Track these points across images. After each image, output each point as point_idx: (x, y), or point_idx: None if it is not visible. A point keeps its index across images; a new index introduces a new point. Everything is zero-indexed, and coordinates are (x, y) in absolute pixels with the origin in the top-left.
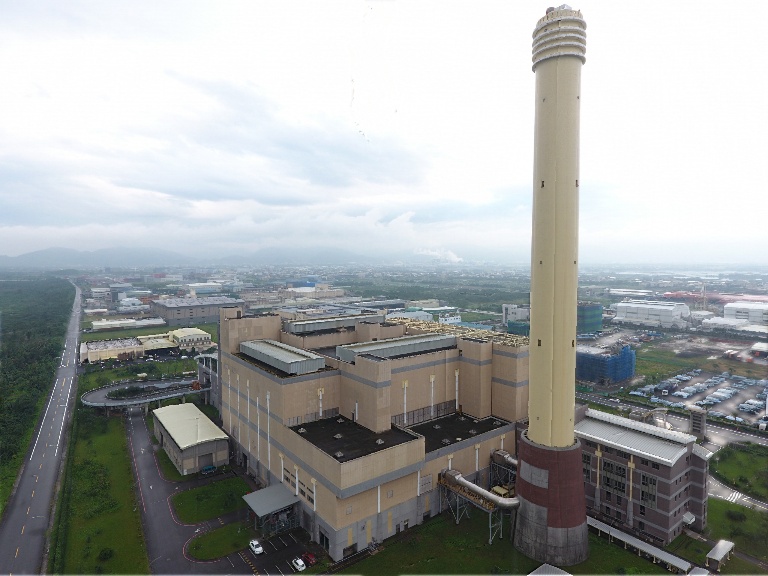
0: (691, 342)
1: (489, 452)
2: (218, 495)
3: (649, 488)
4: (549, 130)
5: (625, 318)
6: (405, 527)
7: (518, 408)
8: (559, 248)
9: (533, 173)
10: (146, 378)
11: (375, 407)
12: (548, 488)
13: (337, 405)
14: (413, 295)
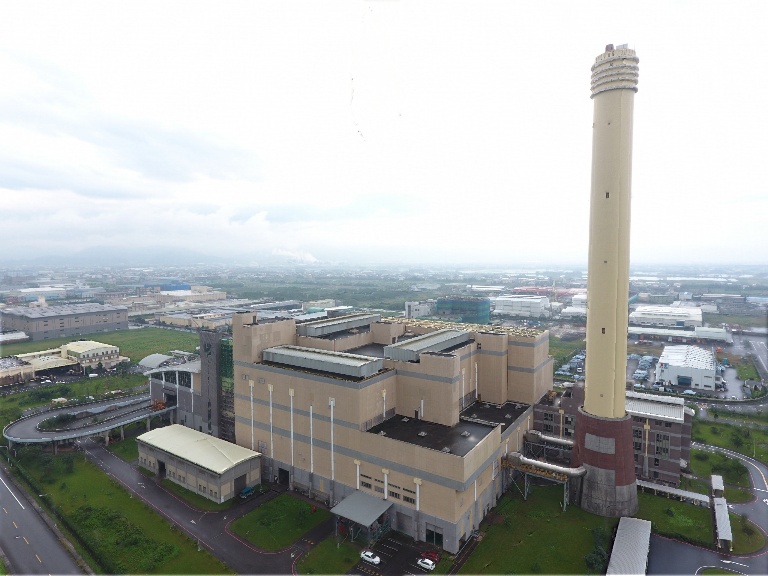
0: (562, 328)
1: (522, 433)
2: (283, 516)
3: (663, 443)
4: (614, 150)
5: (503, 310)
6: (487, 511)
7: (534, 391)
8: (621, 250)
9: (593, 185)
10: (71, 403)
11: (450, 402)
12: (615, 453)
13: (394, 405)
14: (297, 296)
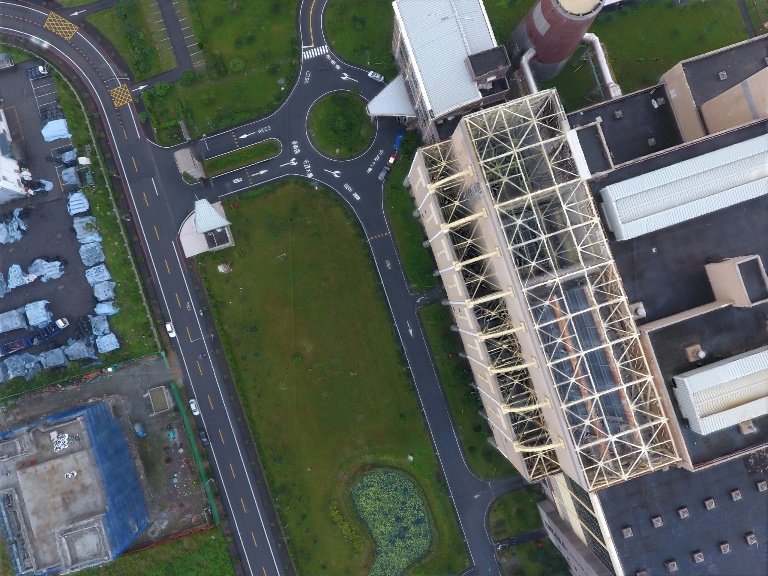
0: None
1: None
2: None
3: None
4: None
5: None
6: None
7: None
8: None
9: None
10: None
11: None
12: None
13: None
14: None
